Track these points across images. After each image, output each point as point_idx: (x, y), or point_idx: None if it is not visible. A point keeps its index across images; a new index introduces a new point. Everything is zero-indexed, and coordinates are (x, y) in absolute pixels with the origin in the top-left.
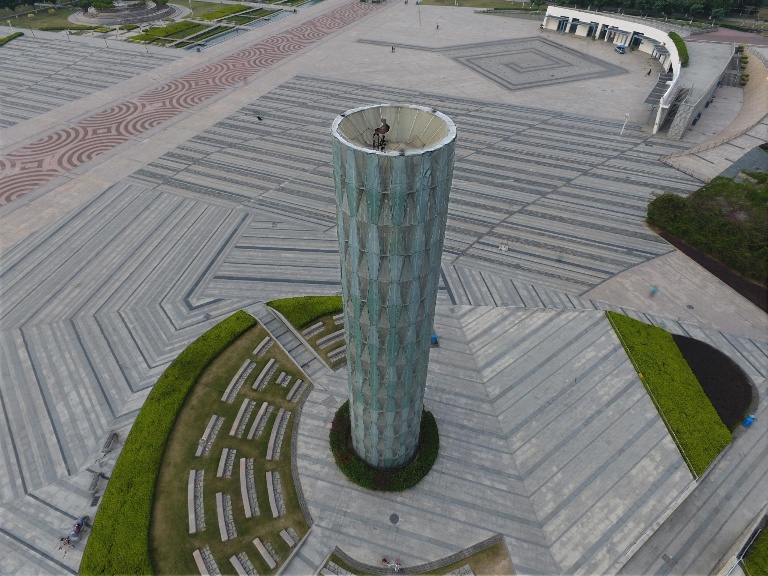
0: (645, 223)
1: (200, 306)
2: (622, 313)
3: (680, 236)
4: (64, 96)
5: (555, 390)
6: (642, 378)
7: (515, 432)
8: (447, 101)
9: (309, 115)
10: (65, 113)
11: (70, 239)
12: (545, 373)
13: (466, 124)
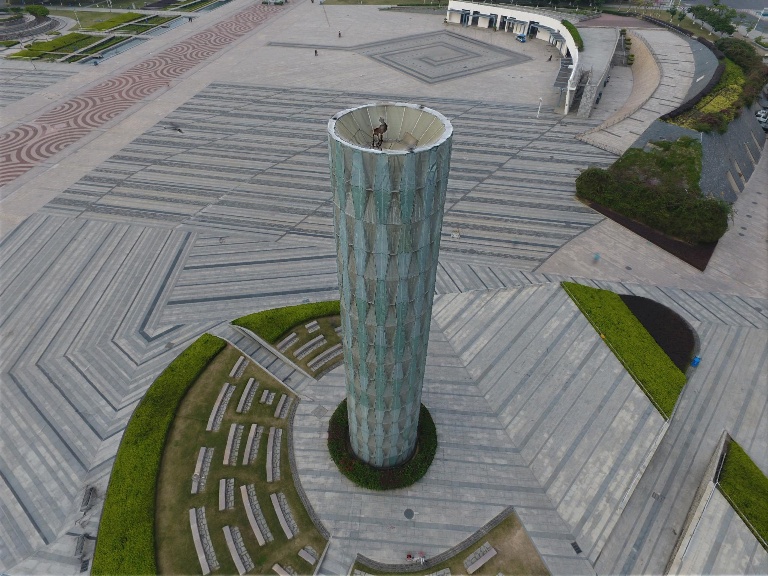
0: (575, 197)
1: (159, 336)
2: (573, 282)
3: (607, 205)
4: None
5: (531, 362)
6: (604, 338)
7: (503, 408)
8: (371, 98)
9: (234, 123)
10: None
11: None
12: (519, 348)
13: None
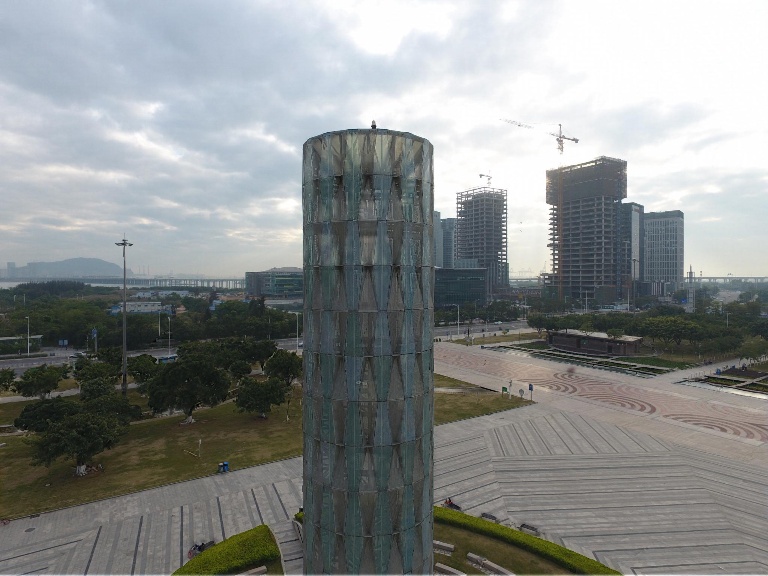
0: None
1: None
2: None
3: None
4: None
5: None
6: None
7: None
8: None
9: None
10: None
11: None
12: None
13: None
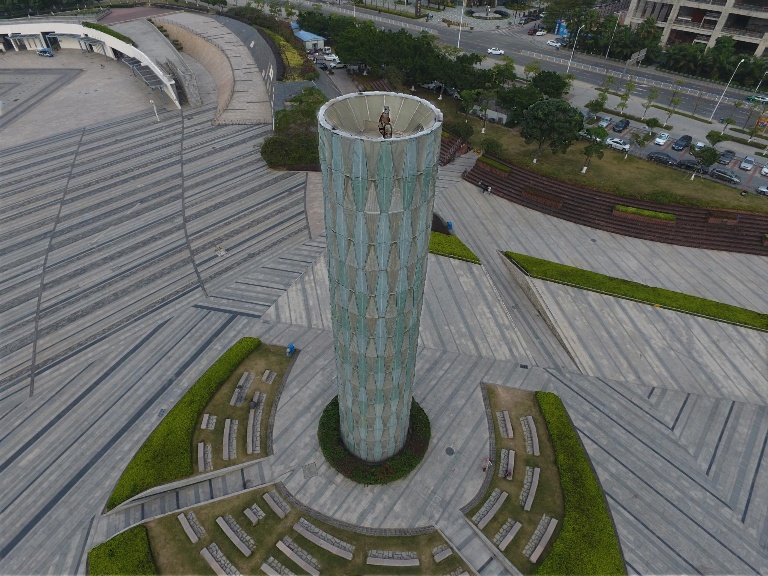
0: (270, 169)
1: None
2: None
3: (299, 163)
4: None
5: None
6: None
7: None
8: None
9: None
10: None
11: None
12: None
13: (1, 187)
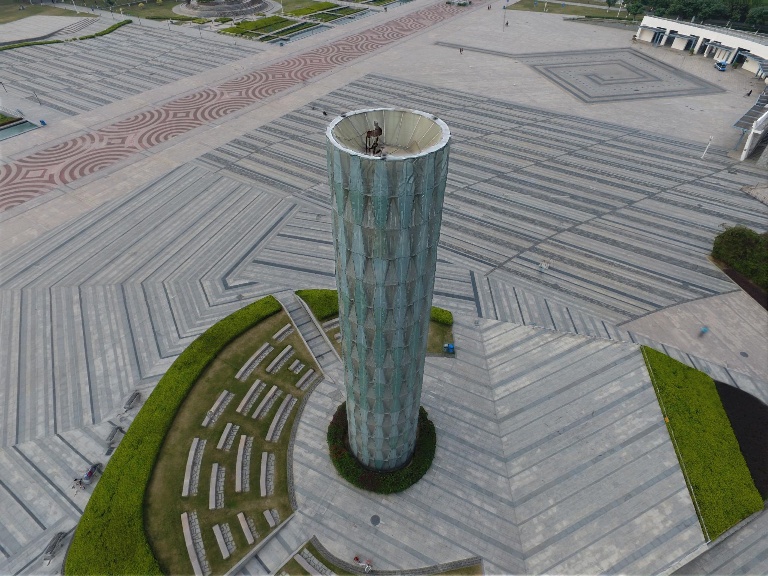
0: (710, 257)
1: (235, 286)
2: (662, 350)
3: (748, 275)
4: (155, 80)
5: (568, 420)
6: (668, 423)
7: (517, 456)
8: (515, 109)
9: None
10: (153, 96)
11: (135, 211)
12: (561, 401)
13: (530, 134)
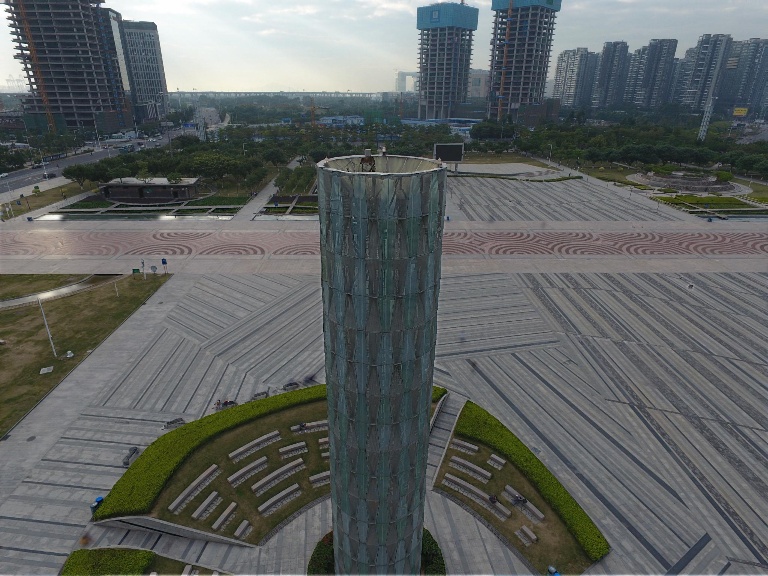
0: None
1: None
2: None
3: None
4: (552, 216)
5: None
6: None
7: None
8: None
9: (761, 308)
10: (537, 225)
11: None
12: None
13: None
